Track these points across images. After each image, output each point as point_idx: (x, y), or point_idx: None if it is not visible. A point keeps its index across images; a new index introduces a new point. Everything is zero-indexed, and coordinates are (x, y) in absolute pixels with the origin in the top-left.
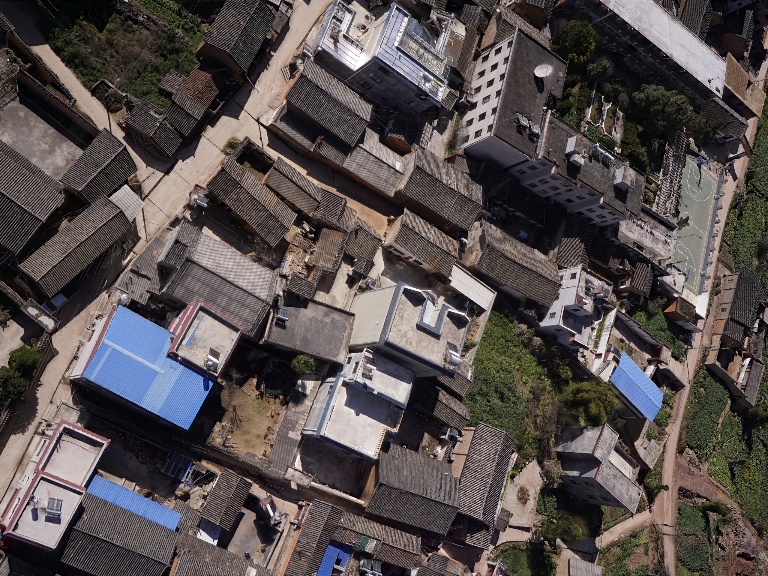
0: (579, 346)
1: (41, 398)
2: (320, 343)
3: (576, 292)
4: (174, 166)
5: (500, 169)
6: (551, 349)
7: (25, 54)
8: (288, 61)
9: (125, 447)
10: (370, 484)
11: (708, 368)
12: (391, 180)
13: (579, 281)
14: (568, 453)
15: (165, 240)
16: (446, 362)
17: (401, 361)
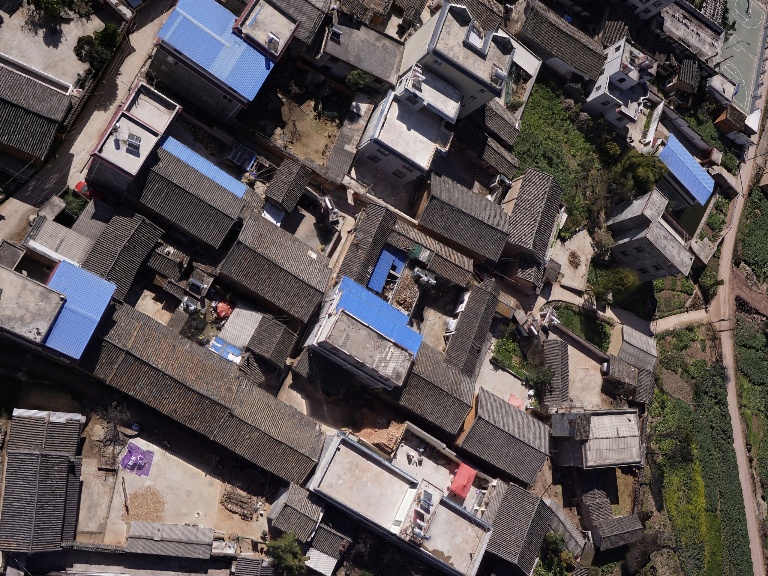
0: (626, 118)
1: (120, 85)
2: (372, 63)
3: (621, 60)
4: None
5: None
6: (598, 122)
7: None
8: None
9: (195, 138)
10: (423, 206)
11: (763, 191)
12: None
13: (623, 50)
14: (618, 224)
15: None
16: (492, 77)
17: (449, 82)
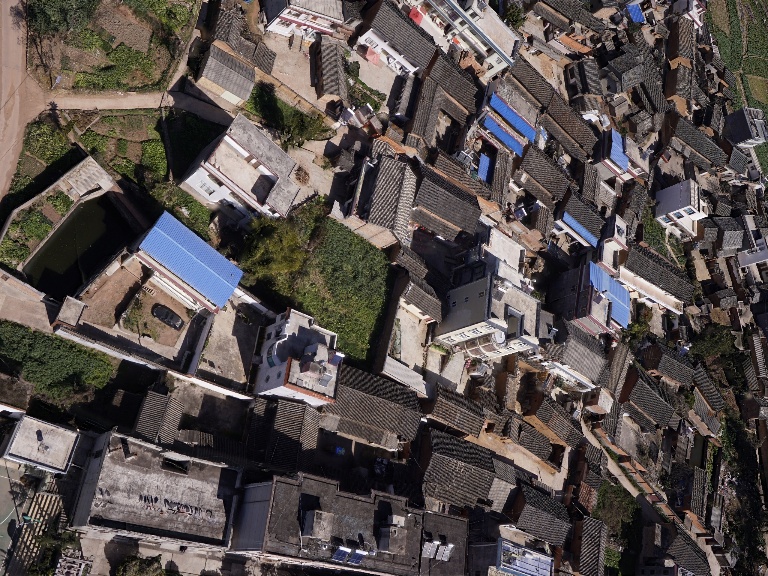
0: None
1: None
2: None
3: None
4: None
5: None
6: None
7: None
8: None
9: None
10: None
11: None
12: None
13: None
14: None
15: None
16: None
17: None
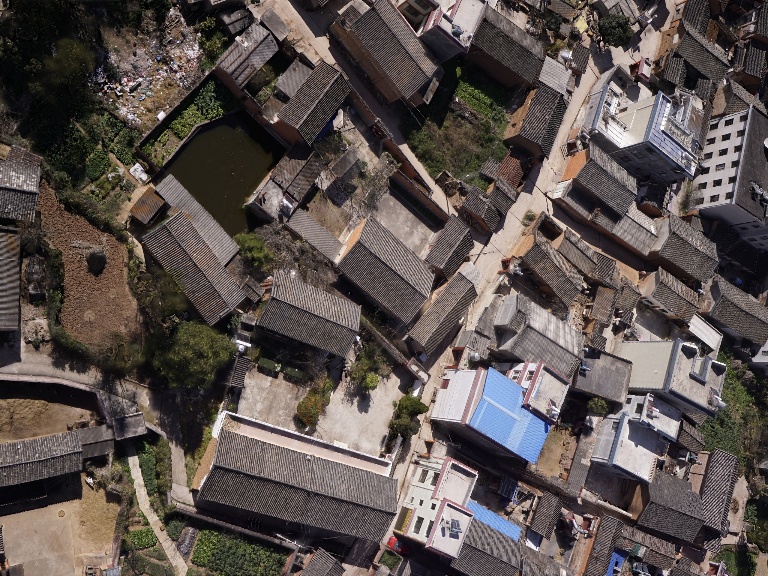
0: None
1: None
2: (608, 387)
3: None
4: (490, 238)
5: (729, 227)
6: (762, 382)
7: (395, 155)
8: (565, 140)
9: None
10: (637, 500)
11: None
12: (647, 242)
13: None
14: None
15: (498, 305)
16: (712, 405)
17: (672, 402)
